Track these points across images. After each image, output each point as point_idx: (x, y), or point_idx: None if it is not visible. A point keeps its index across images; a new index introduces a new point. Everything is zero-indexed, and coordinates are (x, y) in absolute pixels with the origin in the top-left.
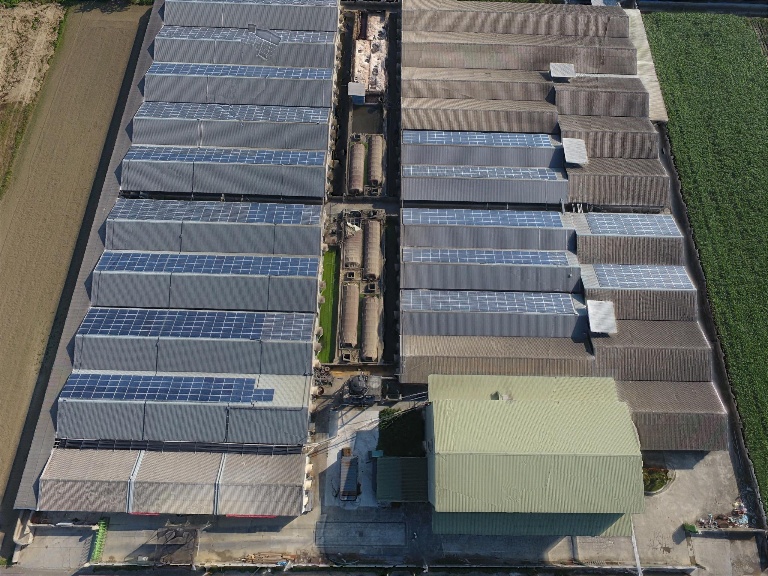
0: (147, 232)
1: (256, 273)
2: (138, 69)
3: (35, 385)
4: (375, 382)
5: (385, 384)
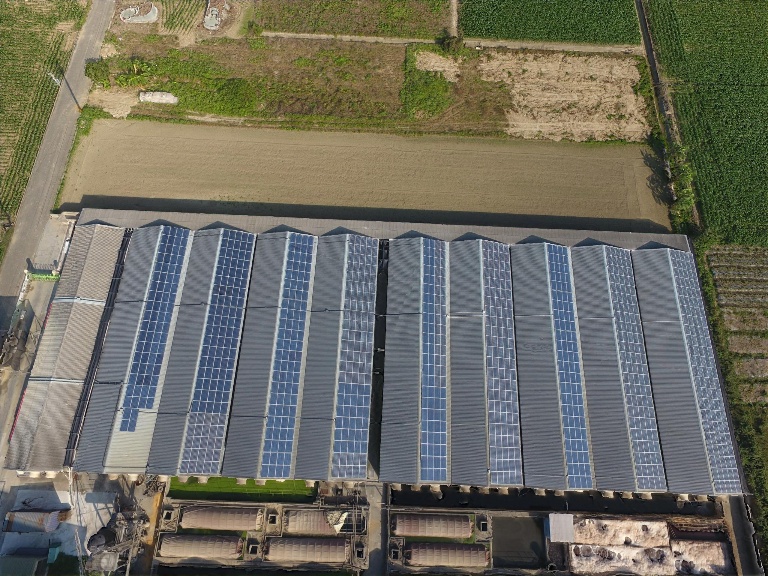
0: (333, 275)
1: (272, 401)
2: (557, 232)
3: (200, 199)
4: (108, 562)
5: (132, 565)
